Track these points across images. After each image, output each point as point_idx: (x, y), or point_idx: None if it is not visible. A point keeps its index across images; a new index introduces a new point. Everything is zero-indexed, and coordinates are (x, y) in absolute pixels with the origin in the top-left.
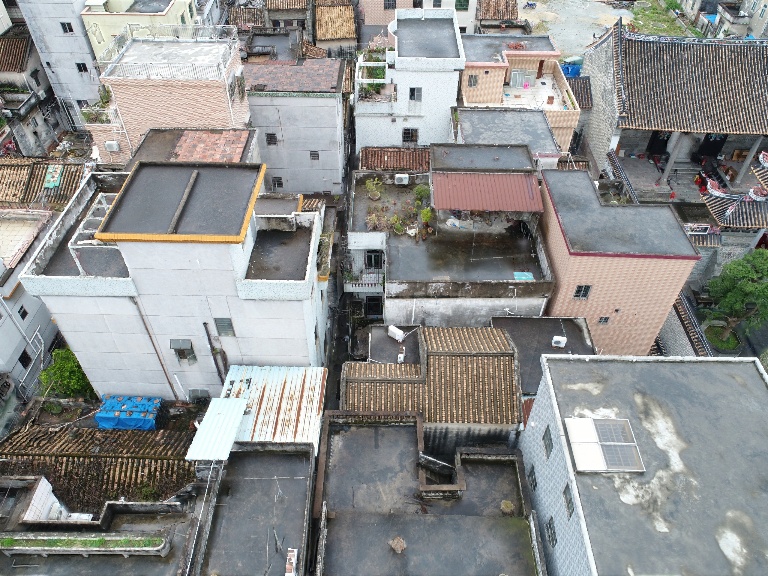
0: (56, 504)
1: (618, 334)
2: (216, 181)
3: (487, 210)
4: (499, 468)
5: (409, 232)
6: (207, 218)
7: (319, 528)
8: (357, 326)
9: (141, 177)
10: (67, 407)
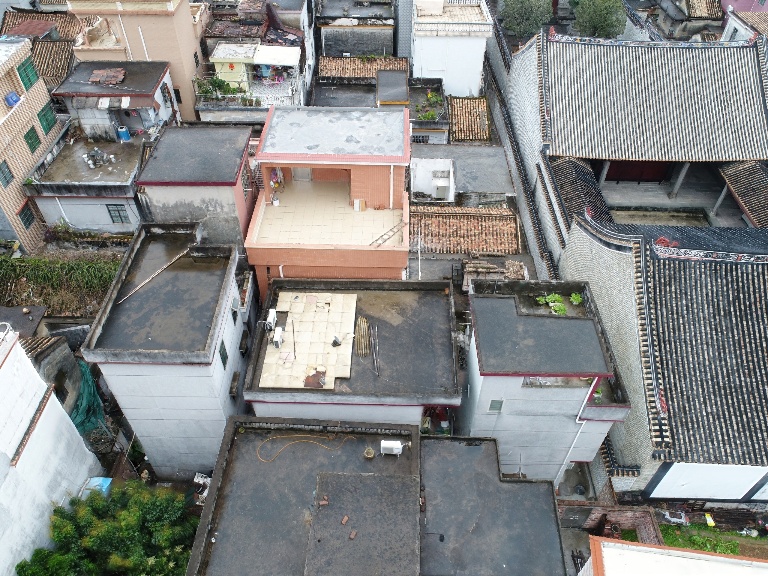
0: None
1: None
2: None
3: None
4: (385, 5)
5: None
6: None
7: None
8: None
9: None
10: None
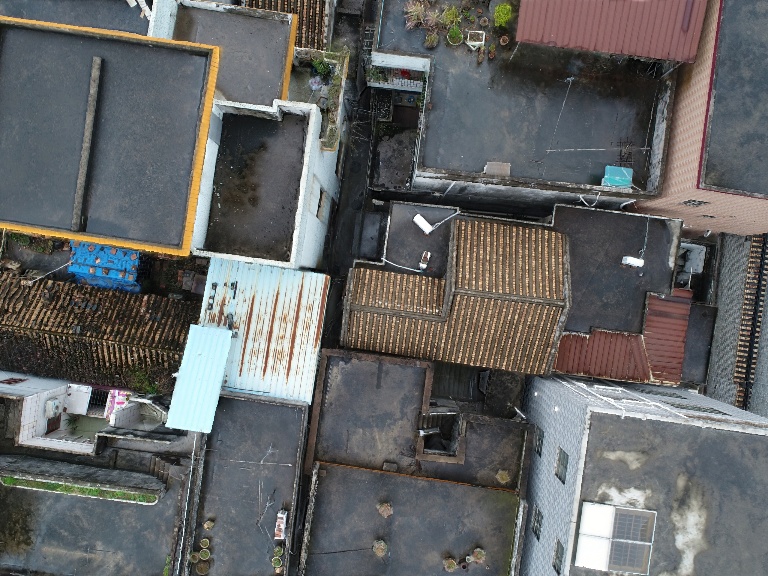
0: (49, 403)
1: (720, 223)
2: (135, 89)
3: (601, 51)
4: (507, 428)
5: (470, 43)
6: (130, 189)
7: (309, 492)
8: (382, 135)
9: (6, 62)
10: (35, 236)
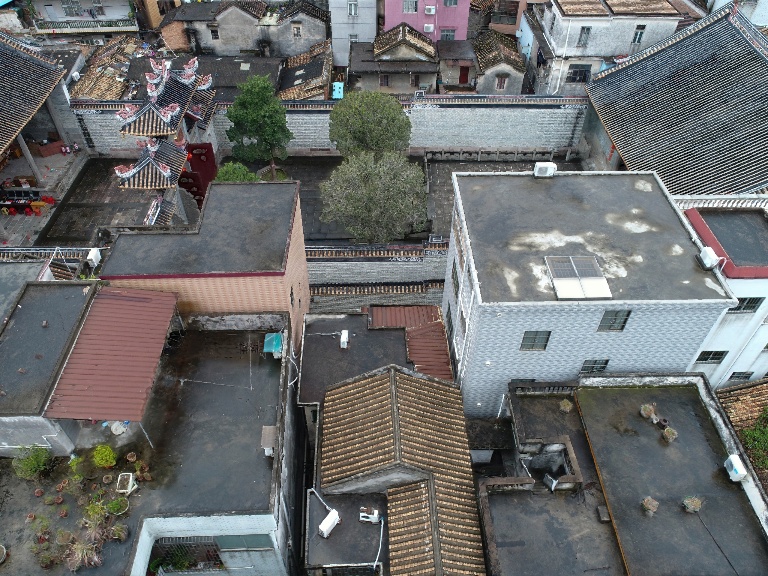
0: None
1: None
2: None
3: None
4: None
5: (130, 490)
6: None
7: None
8: None
9: None
10: None
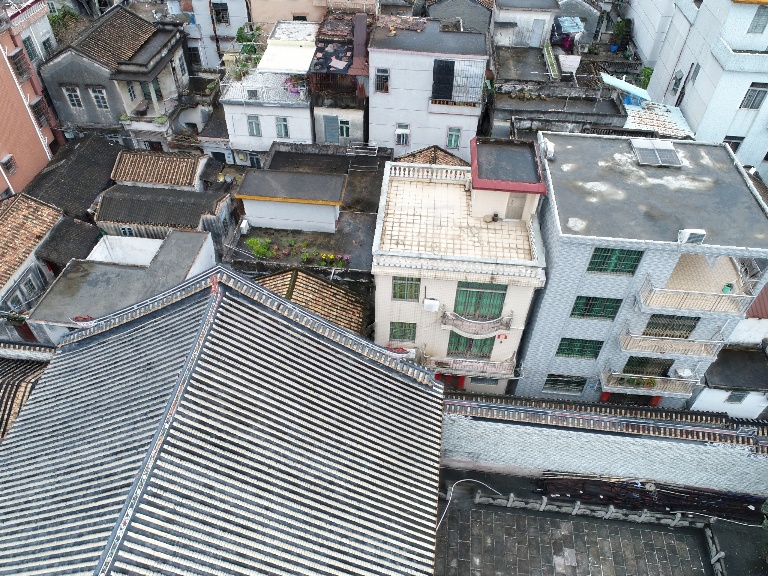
0: None
1: None
2: None
3: None
4: None
5: None
6: None
7: None
8: None
9: None
10: None
